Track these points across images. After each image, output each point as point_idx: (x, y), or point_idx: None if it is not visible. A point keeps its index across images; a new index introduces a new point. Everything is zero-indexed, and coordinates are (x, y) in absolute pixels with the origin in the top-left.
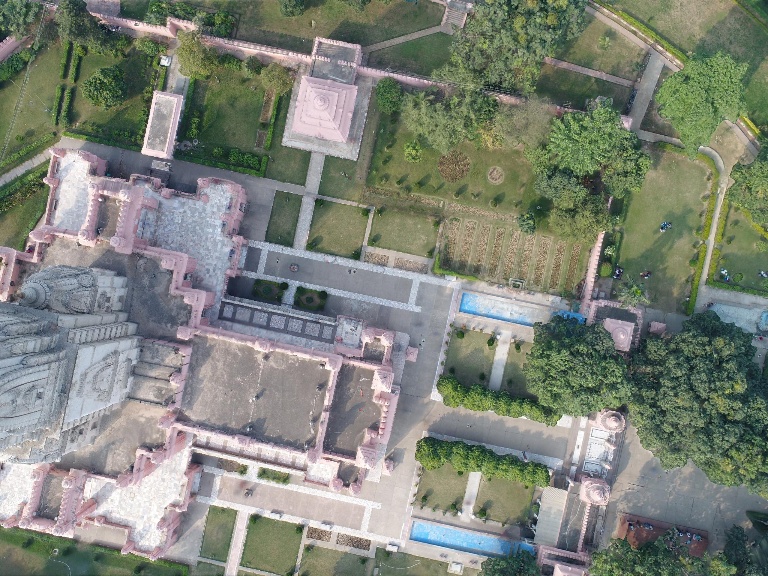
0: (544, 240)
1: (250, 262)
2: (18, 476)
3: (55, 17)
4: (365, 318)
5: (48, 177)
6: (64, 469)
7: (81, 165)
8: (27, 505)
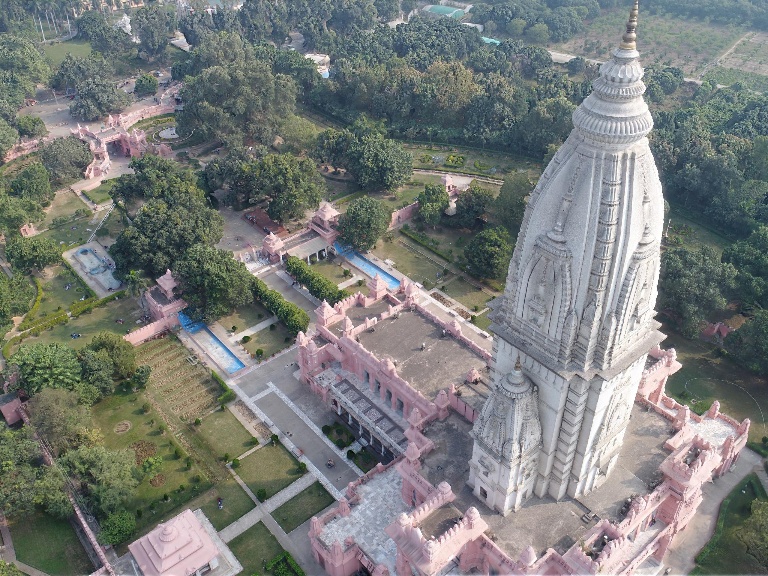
0: None
1: None
2: None
3: None
4: (312, 401)
5: None
6: None
7: None
8: (669, 373)
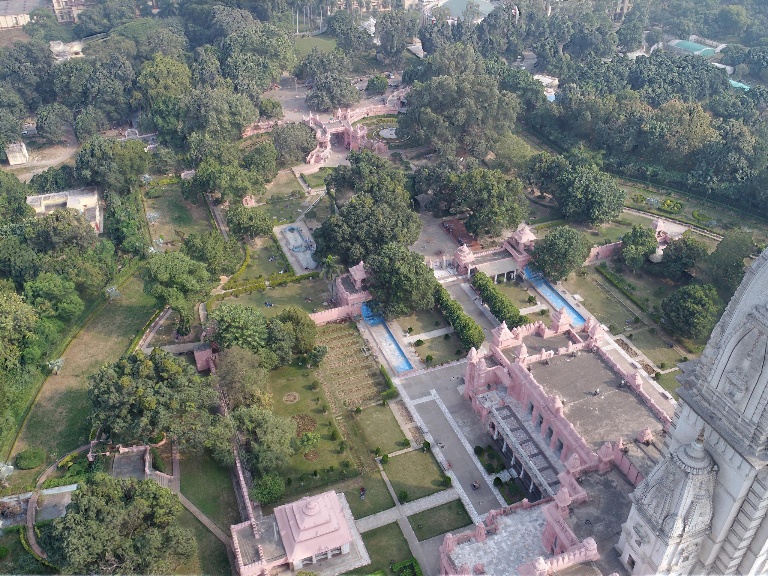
0: None
1: None
2: None
3: None
4: (471, 418)
5: None
6: None
7: None
8: None
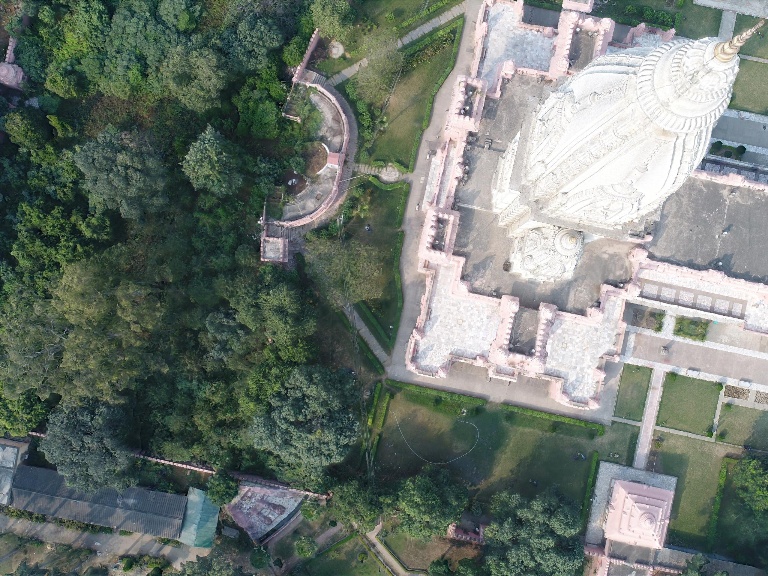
0: None
1: None
2: (445, 327)
3: None
4: None
5: None
6: (525, 306)
7: (510, 14)
8: (496, 340)
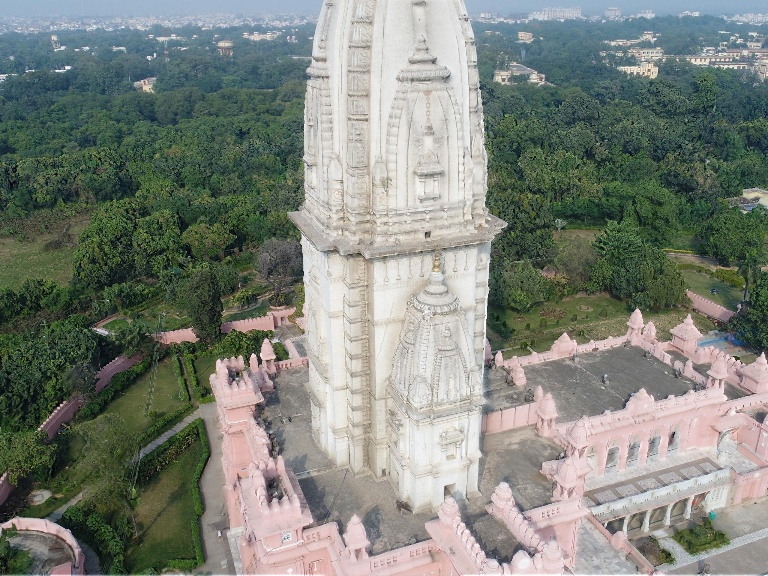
0: (660, 318)
1: None
2: None
3: (194, 281)
4: None
5: None
6: None
7: None
8: None
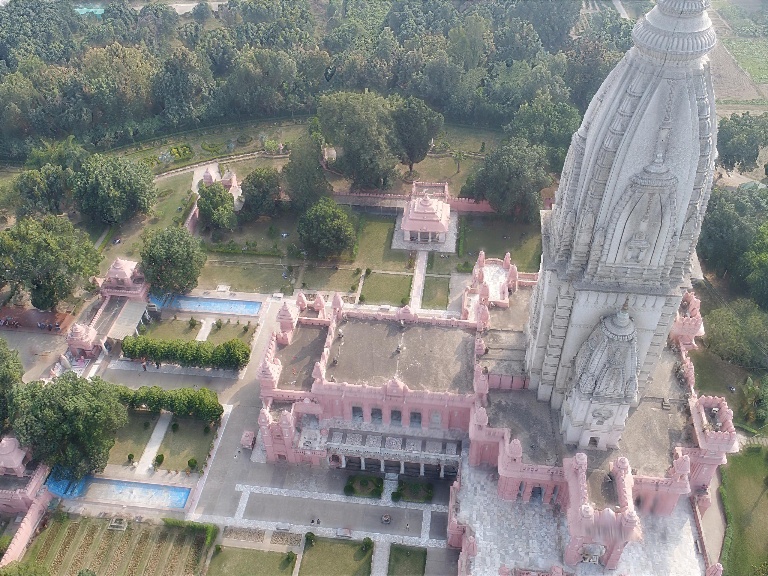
0: None
1: (442, 522)
2: None
3: None
4: (301, 473)
5: (720, 573)
6: None
7: None
8: None
